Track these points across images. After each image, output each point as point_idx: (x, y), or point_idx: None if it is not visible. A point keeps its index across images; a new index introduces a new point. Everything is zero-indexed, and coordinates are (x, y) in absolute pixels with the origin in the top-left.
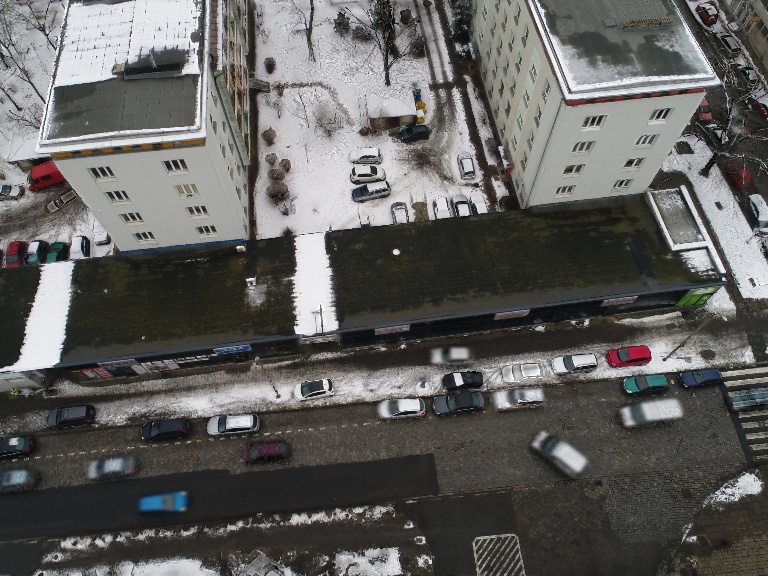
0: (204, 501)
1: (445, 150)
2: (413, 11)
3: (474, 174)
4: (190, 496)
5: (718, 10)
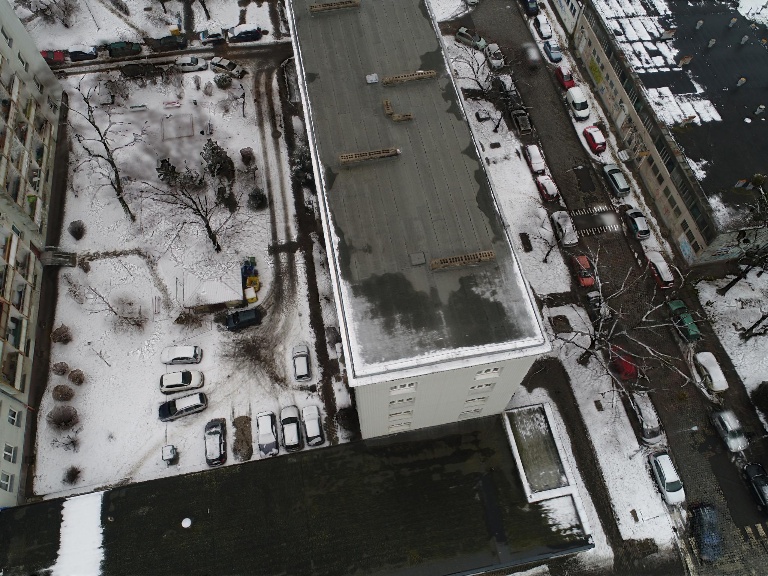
0: None
1: (280, 339)
2: (259, 145)
3: (309, 376)
4: None
5: (608, 133)
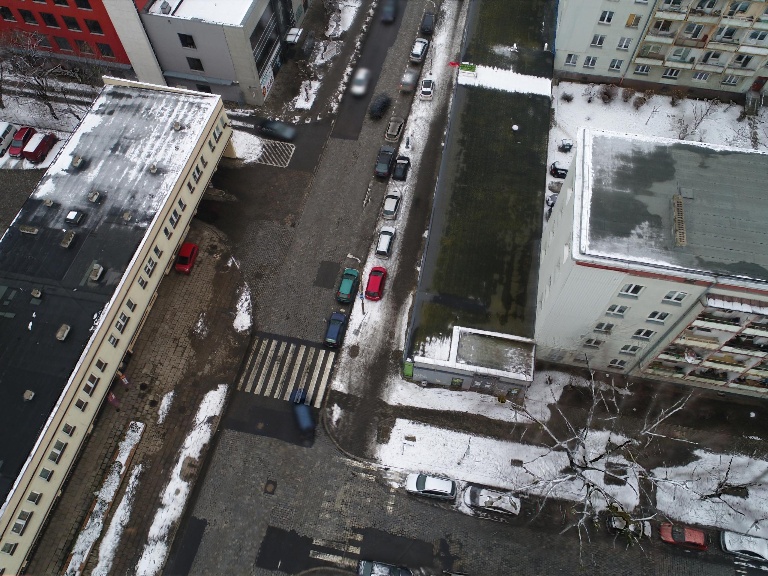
0: (379, 36)
1: None
2: None
3: None
4: (384, 30)
5: None
